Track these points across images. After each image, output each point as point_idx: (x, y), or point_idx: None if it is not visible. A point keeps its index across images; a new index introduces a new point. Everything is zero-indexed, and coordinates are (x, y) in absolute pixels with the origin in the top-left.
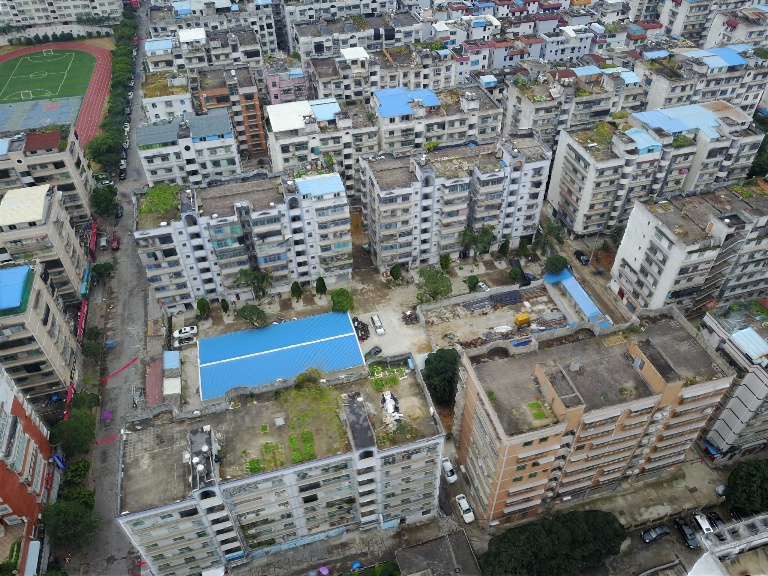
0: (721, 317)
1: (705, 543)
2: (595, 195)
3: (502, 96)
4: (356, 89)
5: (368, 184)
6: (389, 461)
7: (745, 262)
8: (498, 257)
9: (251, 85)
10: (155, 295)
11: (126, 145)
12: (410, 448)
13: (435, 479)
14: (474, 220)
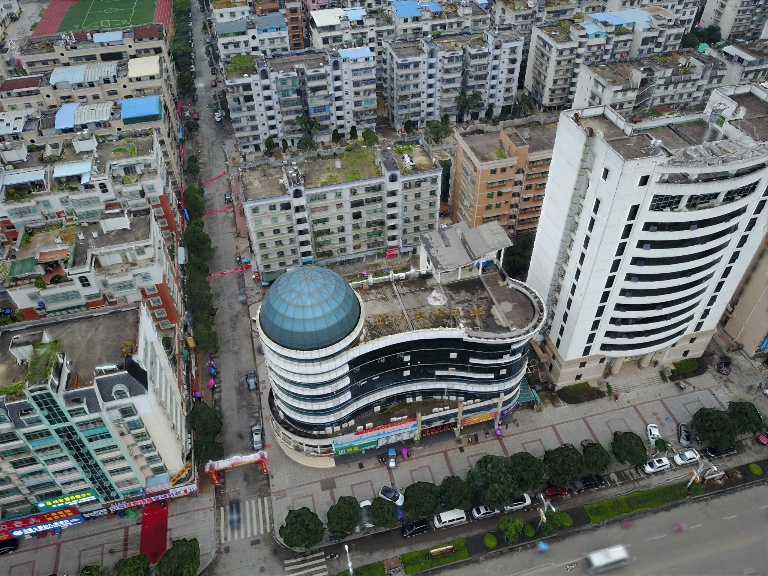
0: (627, 117)
1: None
2: (557, 72)
3: (491, 11)
4: (376, 7)
5: (388, 60)
6: (407, 187)
7: (658, 105)
8: (485, 121)
9: (295, 2)
10: (235, 135)
11: (193, 56)
12: (420, 177)
13: (436, 212)
14: (466, 88)
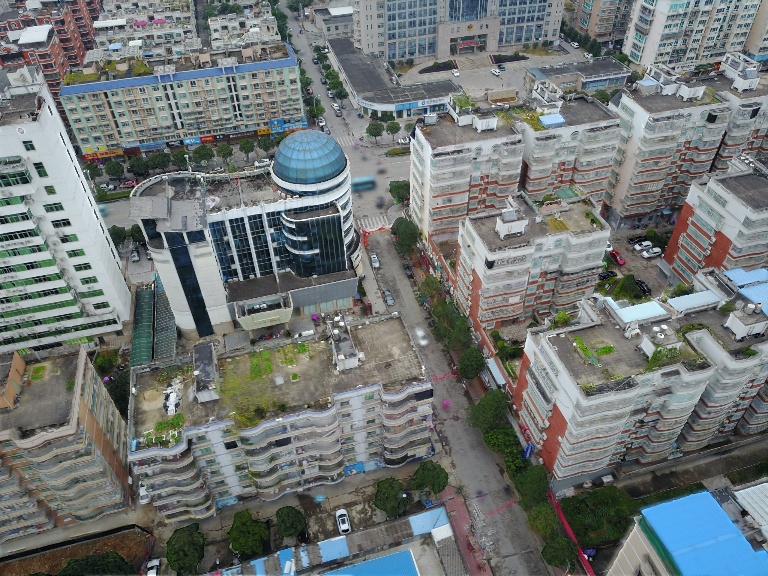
0: None
1: None
2: None
3: None
4: None
5: None
6: None
7: None
8: None
9: None
10: None
11: None
12: (167, 365)
13: None
14: None
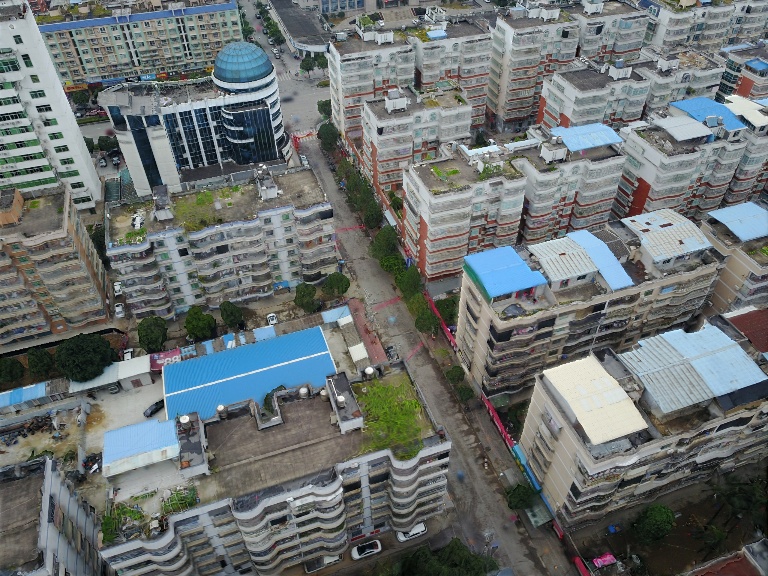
0: None
1: (16, 54)
2: None
3: None
4: None
5: None
6: None
7: None
8: None
9: None
10: None
11: None
12: (133, 202)
13: None
14: None
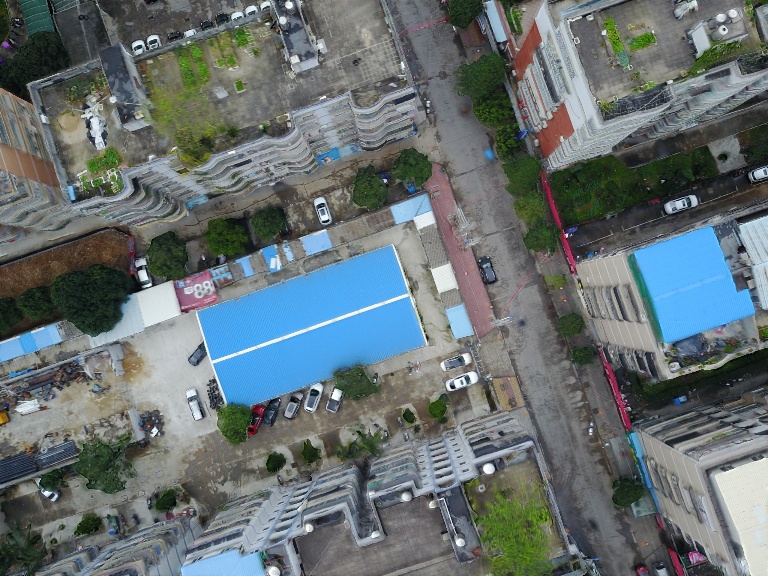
0: None
1: None
2: None
3: None
4: None
5: None
6: None
7: None
8: None
9: None
10: None
11: None
12: (72, 74)
13: None
14: None
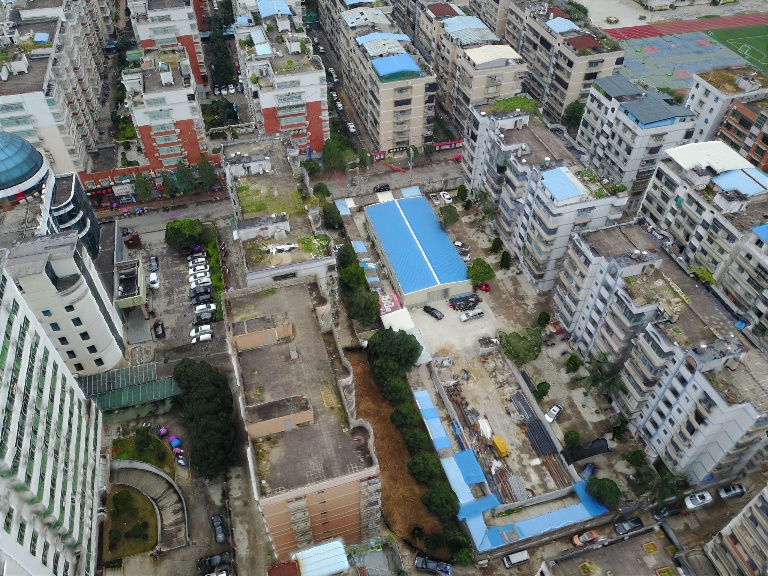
0: None
1: None
2: (745, 529)
3: None
4: None
5: None
6: None
7: None
8: (620, 437)
9: None
10: None
11: None
12: None
13: None
14: None
